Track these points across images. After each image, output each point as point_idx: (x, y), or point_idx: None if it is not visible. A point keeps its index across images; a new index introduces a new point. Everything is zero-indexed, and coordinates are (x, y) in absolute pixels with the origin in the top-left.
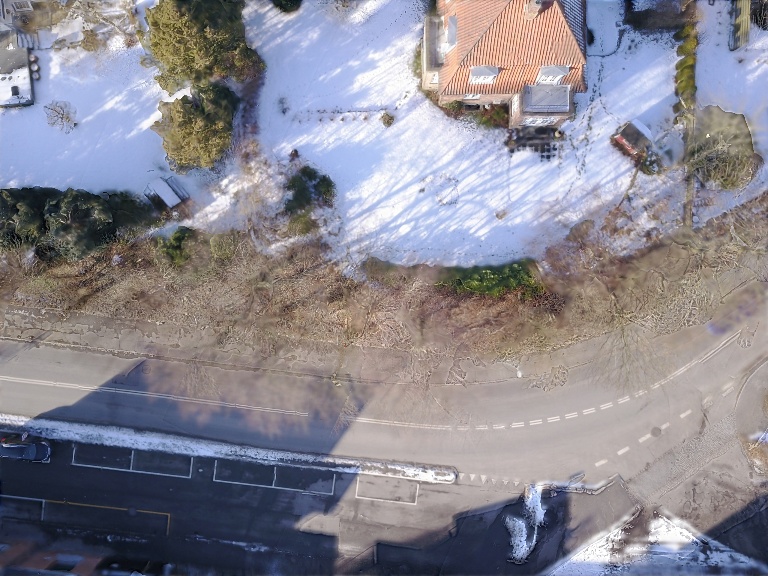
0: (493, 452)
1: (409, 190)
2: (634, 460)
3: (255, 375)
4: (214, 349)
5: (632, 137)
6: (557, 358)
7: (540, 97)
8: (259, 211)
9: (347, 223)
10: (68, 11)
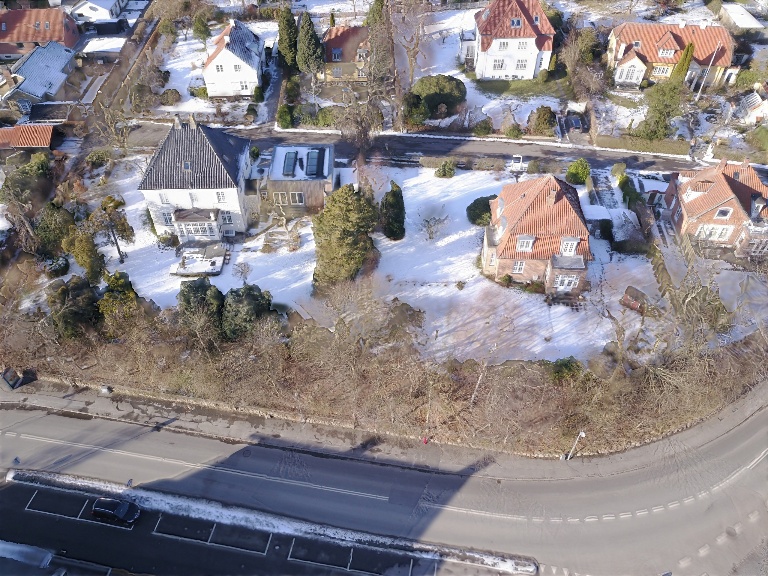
0: (572, 544)
1: (478, 322)
2: (718, 559)
3: (343, 463)
4: (310, 440)
5: (633, 293)
6: (616, 461)
7: (564, 262)
8: (367, 328)
9: (432, 339)
10: (270, 214)
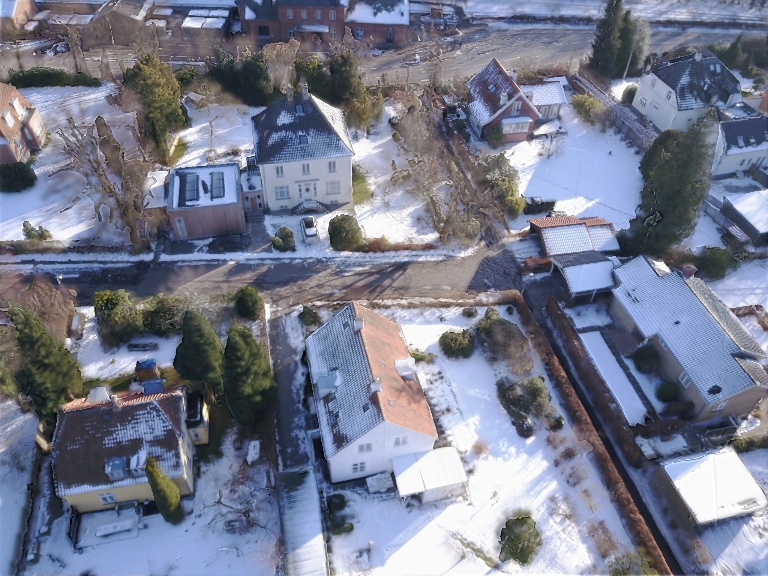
0: None
1: None
2: None
3: None
4: None
5: None
6: None
7: None
8: None
9: None
10: None
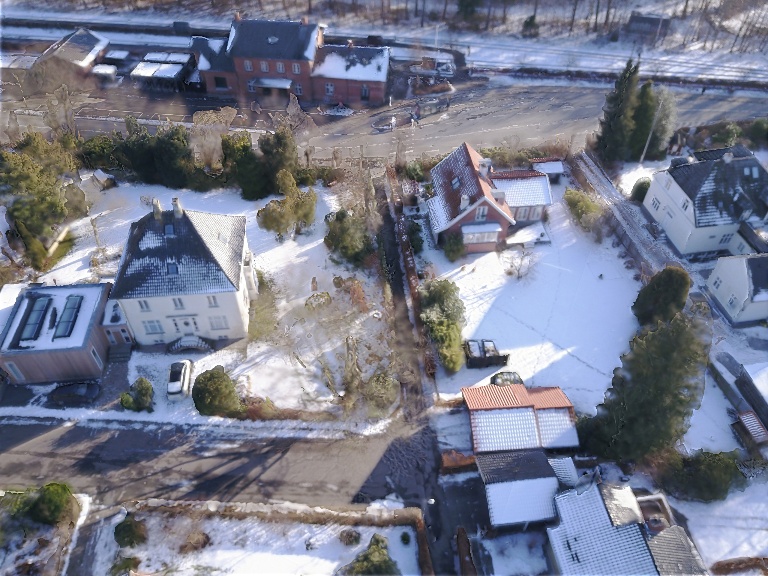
0: None
1: None
2: None
3: None
4: None
5: None
6: None
7: None
8: None
9: None
10: None
